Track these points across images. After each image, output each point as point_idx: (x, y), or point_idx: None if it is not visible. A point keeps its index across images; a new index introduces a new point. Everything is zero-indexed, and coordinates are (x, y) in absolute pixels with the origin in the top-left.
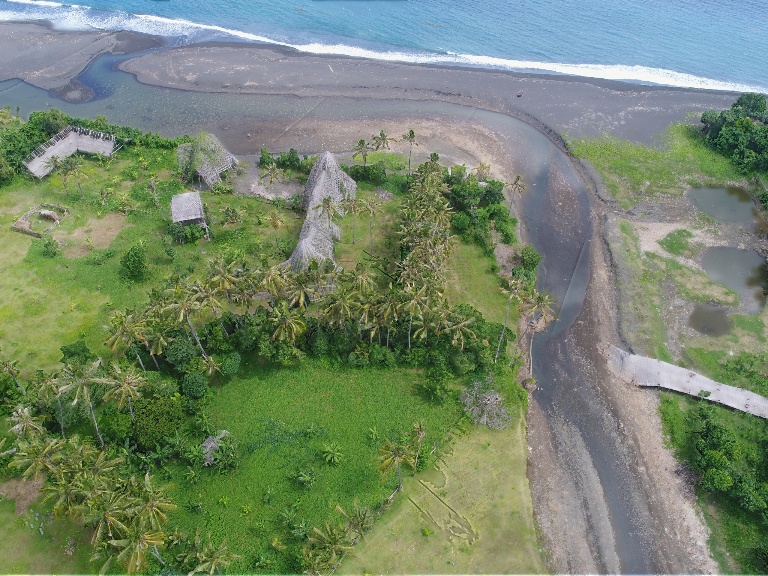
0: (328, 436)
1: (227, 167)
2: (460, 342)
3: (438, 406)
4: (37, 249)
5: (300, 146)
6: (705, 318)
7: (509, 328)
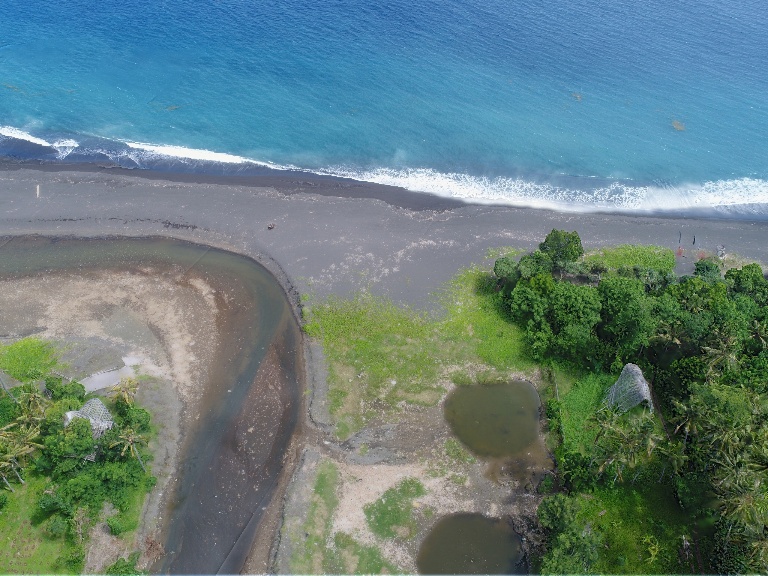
0: None
1: None
2: None
3: None
4: None
5: None
6: None
7: None
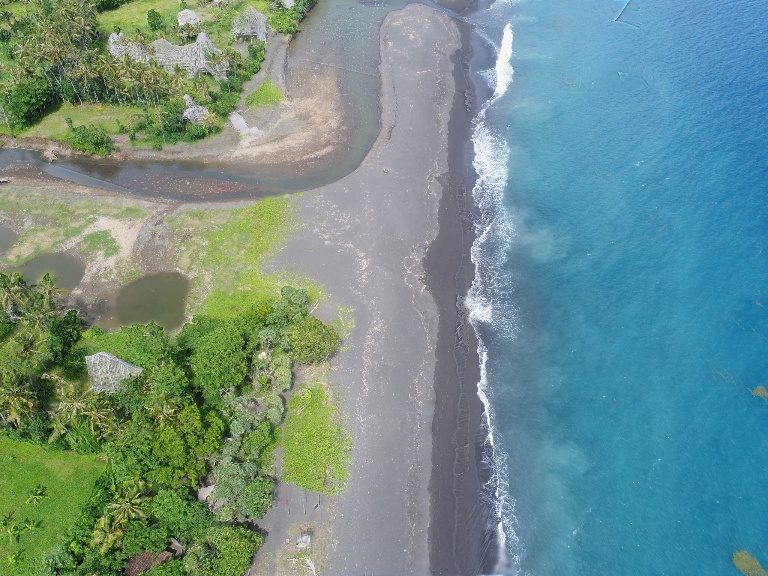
0: (8, 78)
1: (244, 33)
2: (9, 84)
3: (2, 106)
4: (190, 6)
5: (296, 69)
6: (3, 237)
7: (45, 134)
